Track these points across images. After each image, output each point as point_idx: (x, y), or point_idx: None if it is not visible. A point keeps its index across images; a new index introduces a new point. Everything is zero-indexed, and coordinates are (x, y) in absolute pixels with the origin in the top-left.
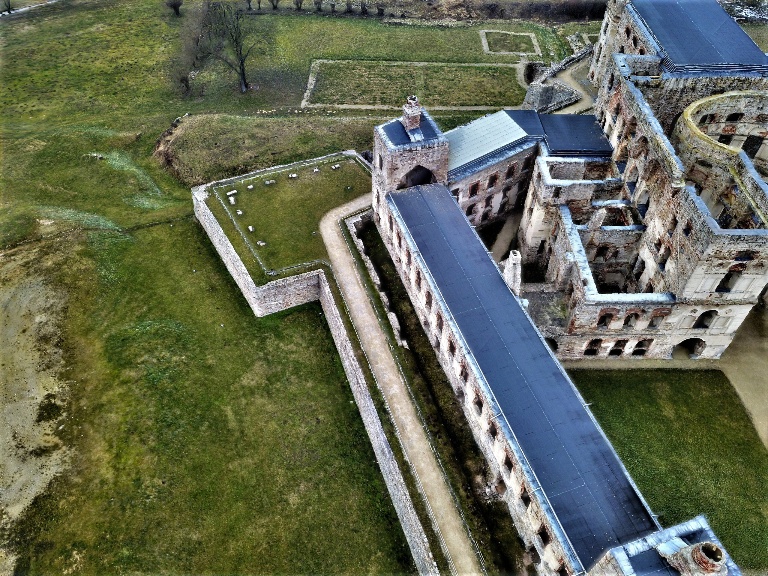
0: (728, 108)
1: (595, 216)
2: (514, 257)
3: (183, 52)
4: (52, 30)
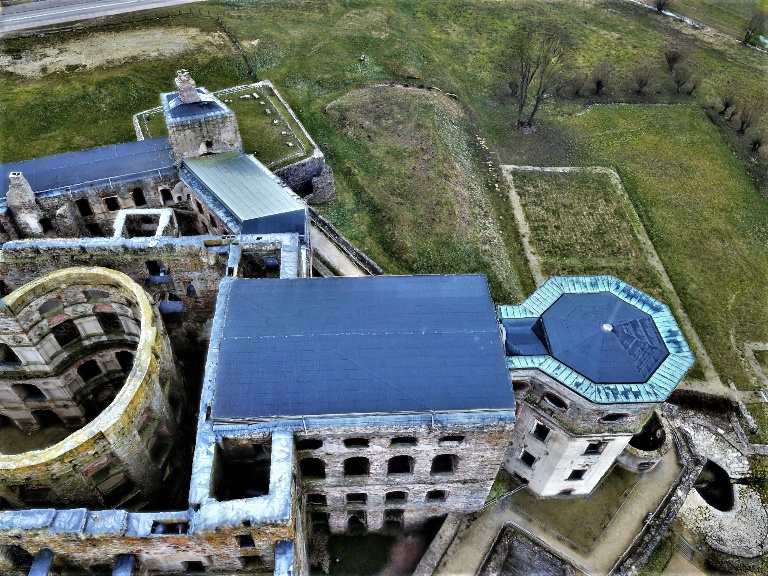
0: None
1: None
2: (11, 173)
3: (589, 85)
4: (589, 15)
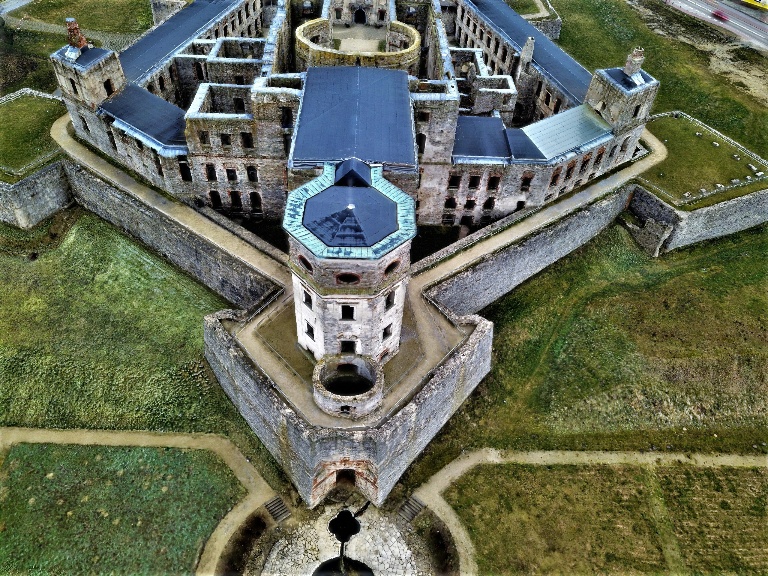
0: None
1: None
2: None
3: None
4: None
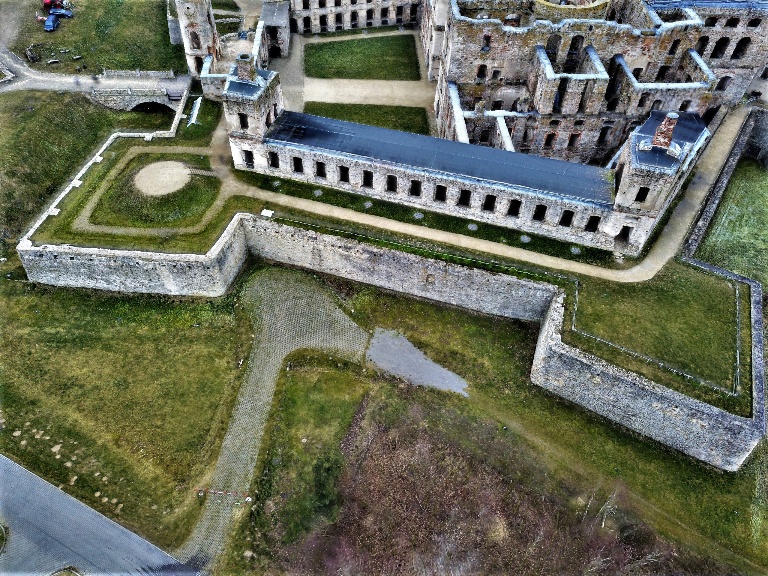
0: None
1: None
2: None
3: None
4: None
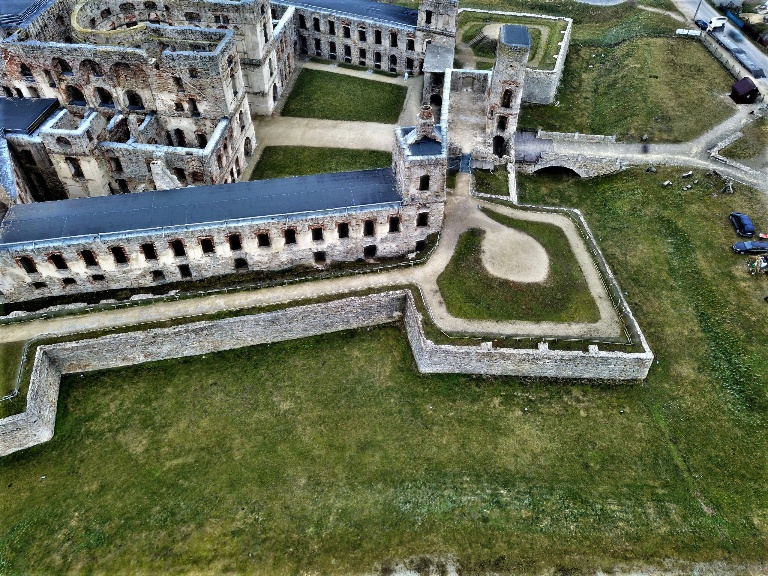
0: (85, 19)
1: (132, 124)
2: (159, 164)
3: None
4: None
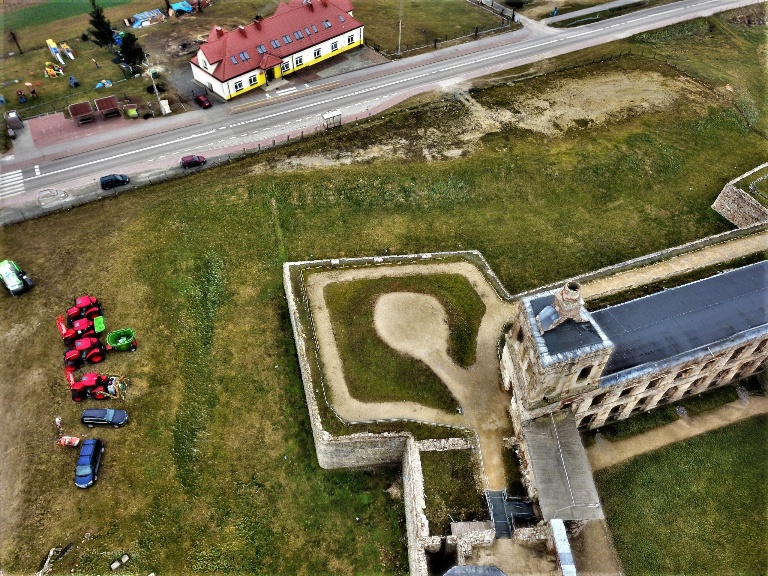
0: None
1: None
2: None
3: None
4: None
